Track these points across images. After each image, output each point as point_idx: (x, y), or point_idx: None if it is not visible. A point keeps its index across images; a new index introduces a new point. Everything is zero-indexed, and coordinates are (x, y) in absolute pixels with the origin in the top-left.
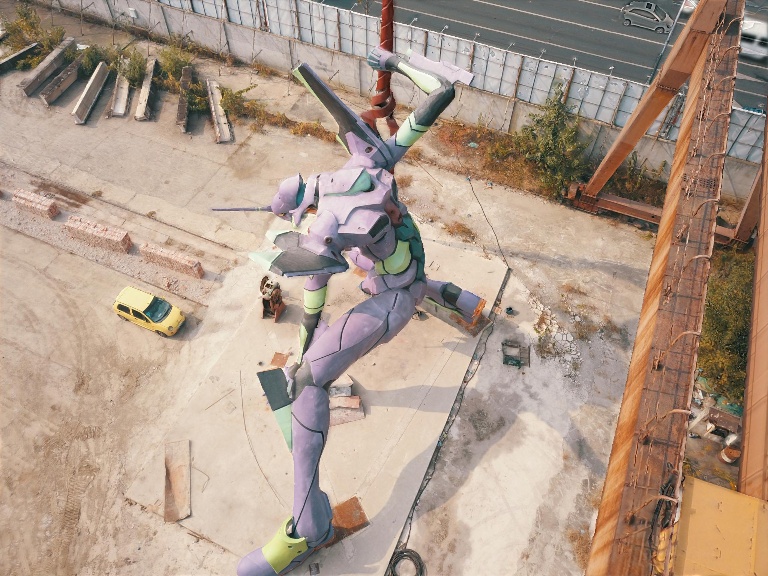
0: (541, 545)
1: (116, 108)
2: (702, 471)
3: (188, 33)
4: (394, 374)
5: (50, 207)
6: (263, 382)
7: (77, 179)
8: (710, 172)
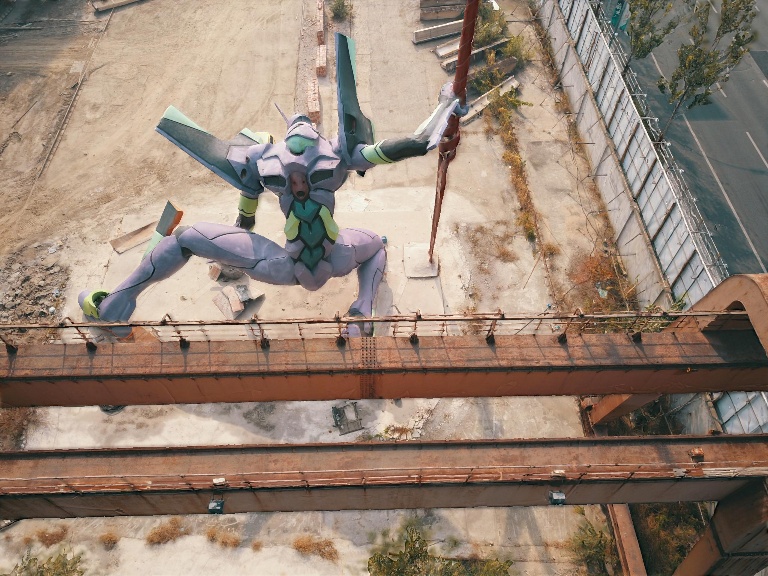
0: None
1: (442, 49)
2: None
3: (551, 38)
4: (280, 327)
5: (320, 67)
6: (166, 209)
7: (361, 68)
8: (391, 361)
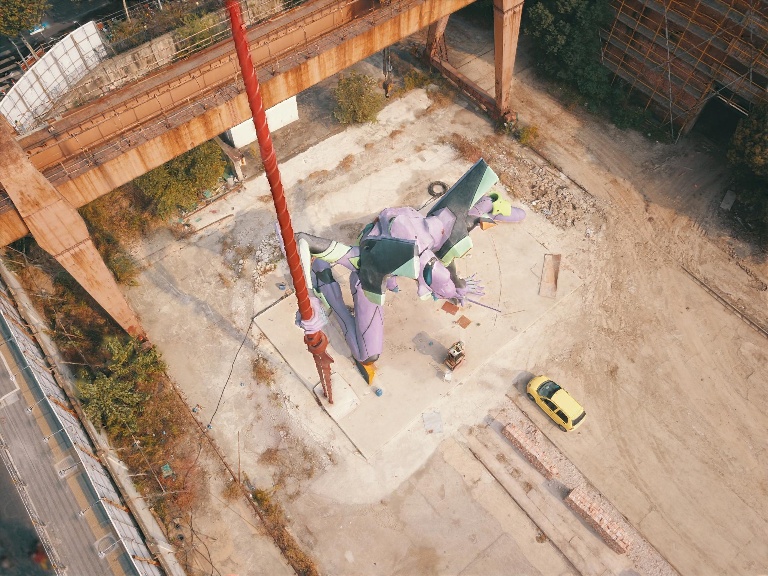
0: (366, 171)
1: None
2: (258, 163)
3: None
4: None
5: None
6: None
7: None
8: None
